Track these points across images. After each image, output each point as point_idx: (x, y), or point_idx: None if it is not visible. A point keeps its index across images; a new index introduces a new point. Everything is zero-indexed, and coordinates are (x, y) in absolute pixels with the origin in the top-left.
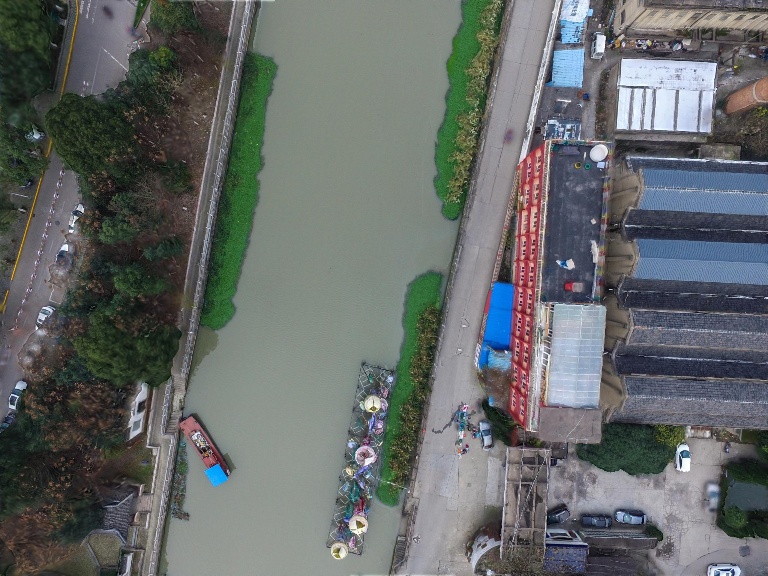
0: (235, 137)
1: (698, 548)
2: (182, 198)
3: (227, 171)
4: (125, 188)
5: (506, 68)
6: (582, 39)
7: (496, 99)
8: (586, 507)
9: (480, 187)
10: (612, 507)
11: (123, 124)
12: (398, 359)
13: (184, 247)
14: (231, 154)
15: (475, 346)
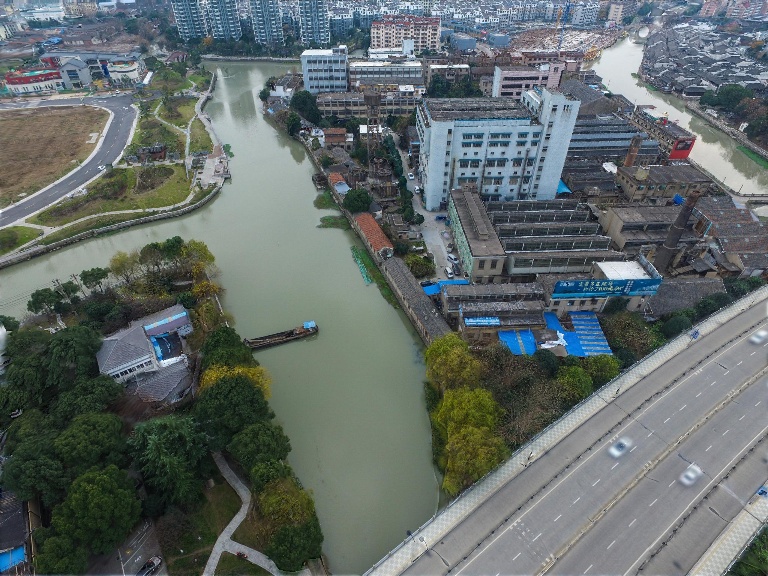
0: None
1: None
2: None
3: None
4: None
5: None
6: None
7: None
8: None
9: None
10: None
11: None
12: None
13: None
14: None
15: None
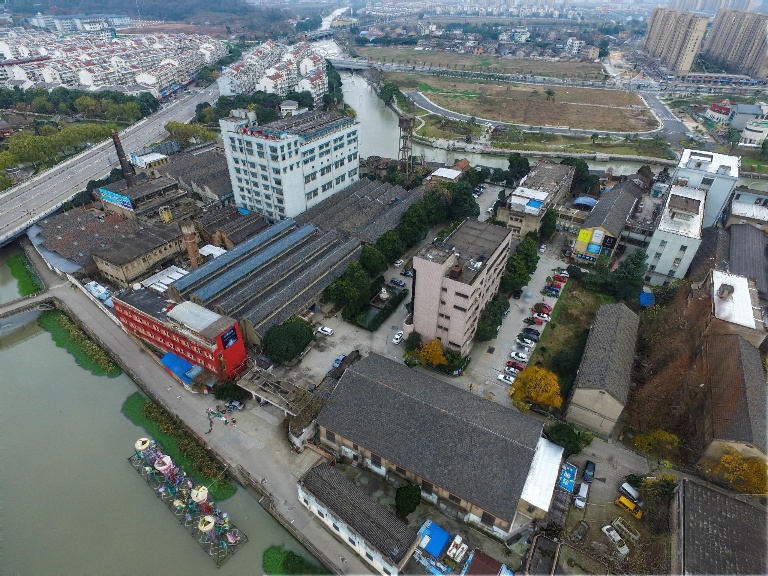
0: None
1: (381, 343)
2: None
3: None
4: None
5: (87, 322)
6: (111, 293)
7: (93, 330)
8: (320, 378)
9: (118, 353)
10: (330, 368)
11: None
12: (151, 438)
13: None
14: None
15: (184, 389)
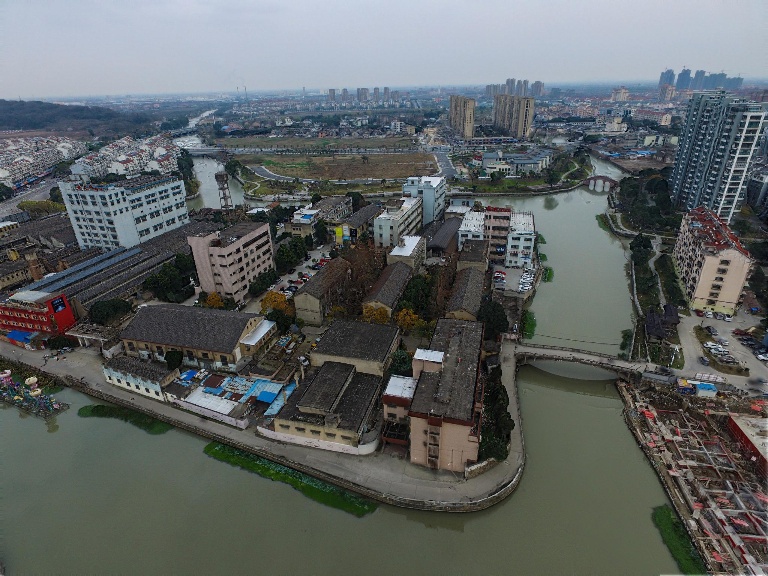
0: None
1: None
2: None
3: None
4: None
5: None
6: None
7: None
8: None
9: None
10: None
11: None
12: None
13: None
14: None
15: None
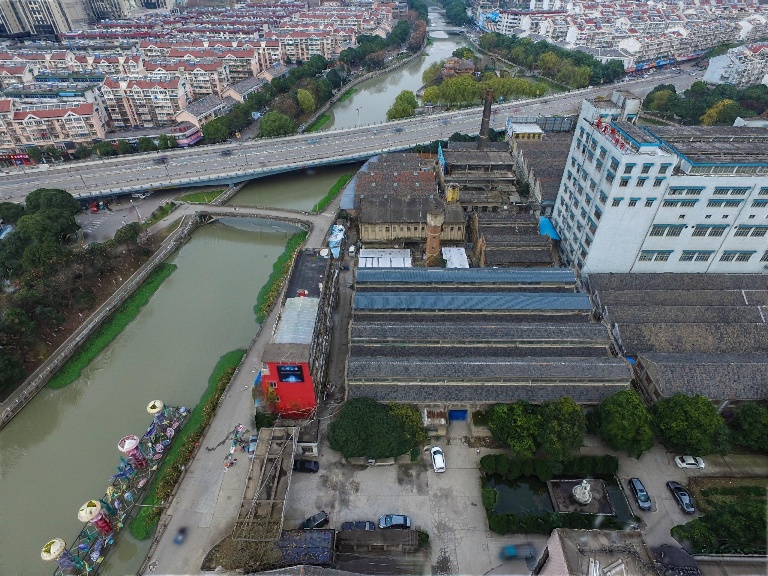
0: (136, 293)
1: (478, 563)
2: (82, 313)
3: (121, 305)
4: (49, 277)
5: None
6: (339, 245)
7: None
8: (349, 517)
9: None
10: (376, 516)
11: (68, 252)
12: (197, 404)
13: (66, 336)
14: (128, 299)
15: None
